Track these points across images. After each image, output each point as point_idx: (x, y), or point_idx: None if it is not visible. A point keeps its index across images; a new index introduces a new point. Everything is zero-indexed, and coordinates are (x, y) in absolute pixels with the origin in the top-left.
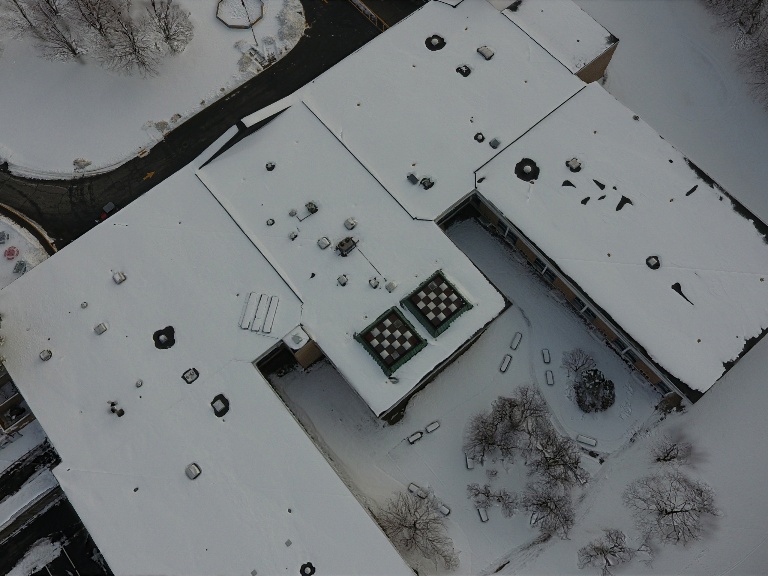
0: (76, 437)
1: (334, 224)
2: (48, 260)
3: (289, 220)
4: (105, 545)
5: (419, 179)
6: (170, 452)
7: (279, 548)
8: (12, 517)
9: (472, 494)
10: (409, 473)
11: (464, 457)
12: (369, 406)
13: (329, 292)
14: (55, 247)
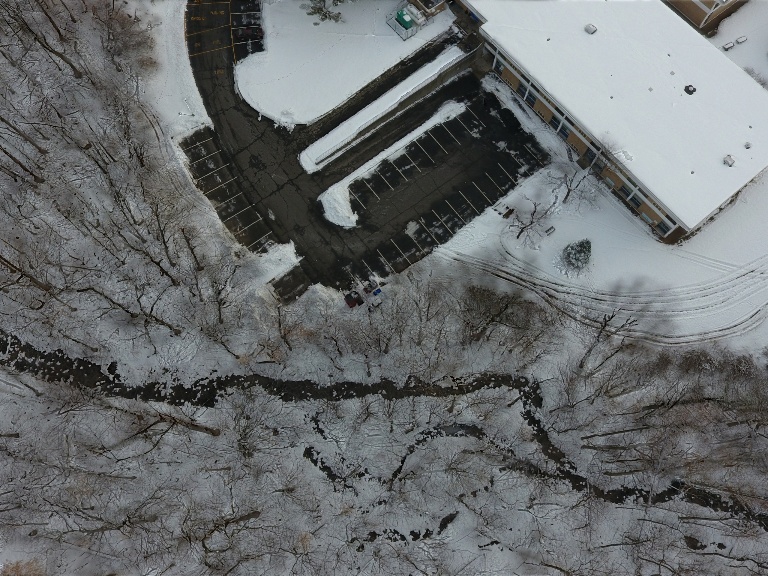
0: (494, 7)
1: None
2: None
3: None
4: (533, 71)
5: None
6: (570, 17)
7: (666, 76)
8: (439, 71)
9: None
10: None
11: None
12: None
13: None
14: None
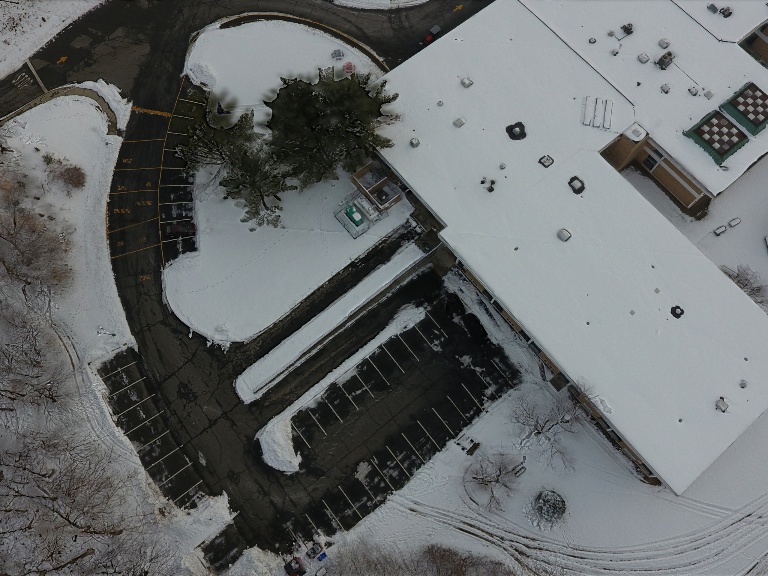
0: (455, 207)
1: (650, 43)
2: (400, 67)
3: (609, 39)
4: (499, 290)
5: (718, 9)
6: (541, 220)
7: (650, 294)
8: (394, 278)
9: None
10: (719, 258)
11: (765, 247)
12: (707, 188)
13: (655, 98)
14: (385, 65)
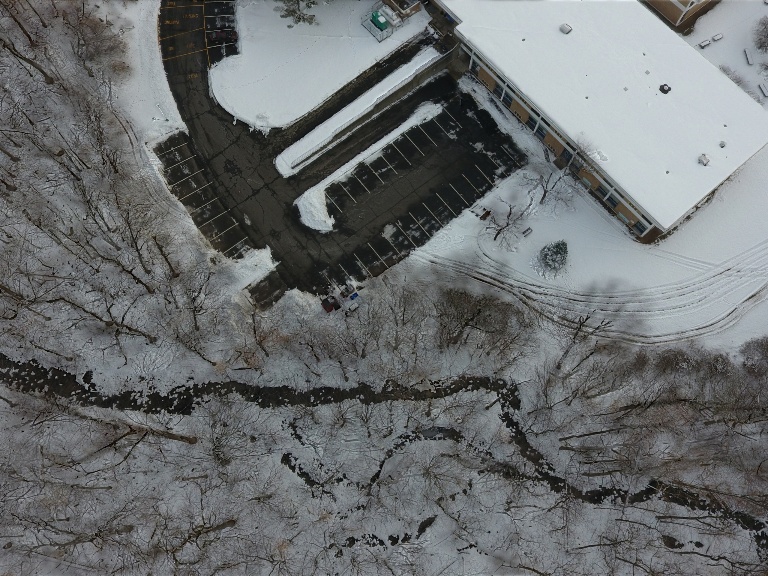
0: (469, 7)
1: None
2: None
3: None
4: (509, 72)
5: None
6: (545, 17)
7: (641, 75)
8: (415, 72)
9: (763, 69)
10: None
11: (745, 57)
12: None
13: None
14: None
